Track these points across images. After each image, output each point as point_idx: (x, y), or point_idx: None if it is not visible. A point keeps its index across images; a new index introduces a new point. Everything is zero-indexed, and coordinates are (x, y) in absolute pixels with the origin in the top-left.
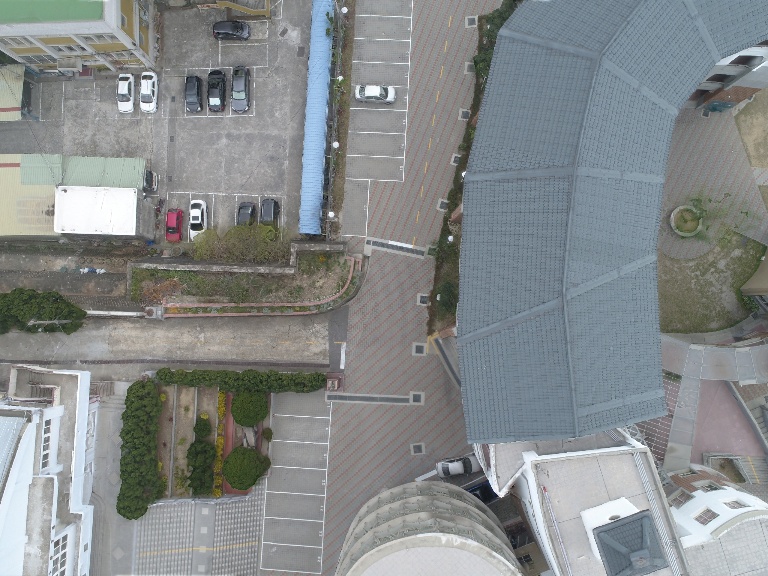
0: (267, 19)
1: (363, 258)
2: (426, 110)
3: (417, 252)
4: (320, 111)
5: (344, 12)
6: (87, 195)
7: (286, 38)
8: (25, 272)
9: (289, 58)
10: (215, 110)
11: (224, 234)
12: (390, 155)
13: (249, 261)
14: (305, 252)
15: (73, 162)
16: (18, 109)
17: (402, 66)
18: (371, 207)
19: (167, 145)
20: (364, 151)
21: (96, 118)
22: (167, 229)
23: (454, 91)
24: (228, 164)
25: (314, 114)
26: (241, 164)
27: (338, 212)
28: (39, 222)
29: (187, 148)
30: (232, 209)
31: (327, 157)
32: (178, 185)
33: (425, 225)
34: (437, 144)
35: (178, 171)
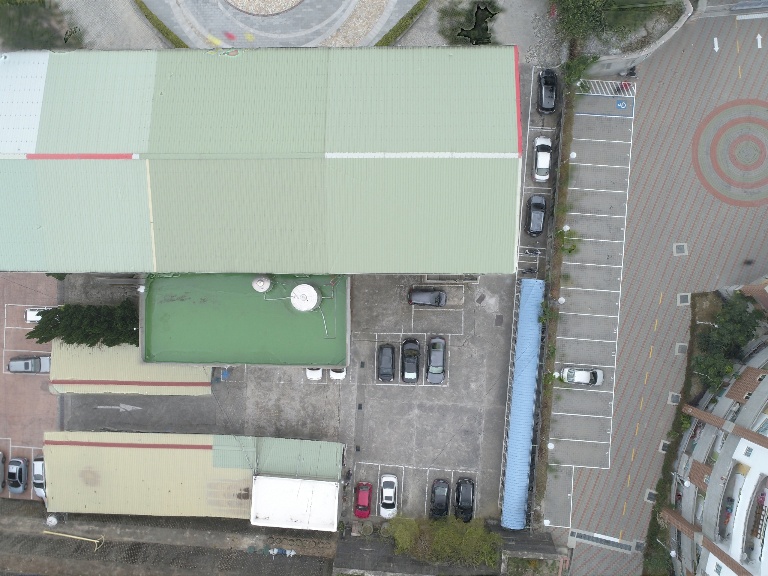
0: (464, 284)
1: (567, 552)
2: (634, 392)
3: (624, 547)
4: (529, 400)
5: (561, 303)
6: (283, 482)
7: (483, 305)
8: (213, 554)
9: (486, 327)
10: (409, 382)
11: (414, 509)
12: (595, 440)
13: (456, 563)
14: (515, 557)
15: (267, 444)
16: (208, 384)
17: (609, 344)
18: (575, 496)
19: (355, 413)
20: (568, 435)
21: (281, 381)
22: (357, 505)
23: (664, 373)
24: (420, 436)
25: (522, 403)
26: (433, 437)
27: (540, 500)
28: (230, 504)
29: (376, 417)
30: (423, 483)
31: (533, 447)
32: (366, 455)
33: (632, 518)
34: (645, 429)
35: (366, 441)
